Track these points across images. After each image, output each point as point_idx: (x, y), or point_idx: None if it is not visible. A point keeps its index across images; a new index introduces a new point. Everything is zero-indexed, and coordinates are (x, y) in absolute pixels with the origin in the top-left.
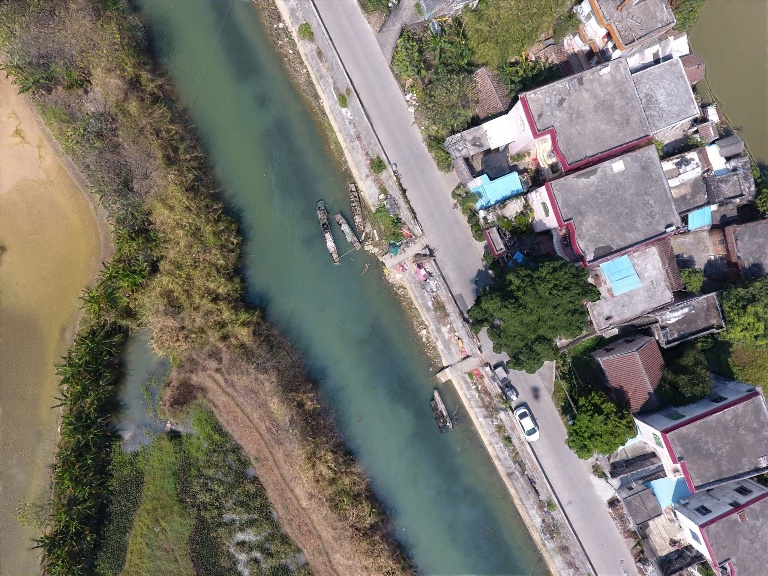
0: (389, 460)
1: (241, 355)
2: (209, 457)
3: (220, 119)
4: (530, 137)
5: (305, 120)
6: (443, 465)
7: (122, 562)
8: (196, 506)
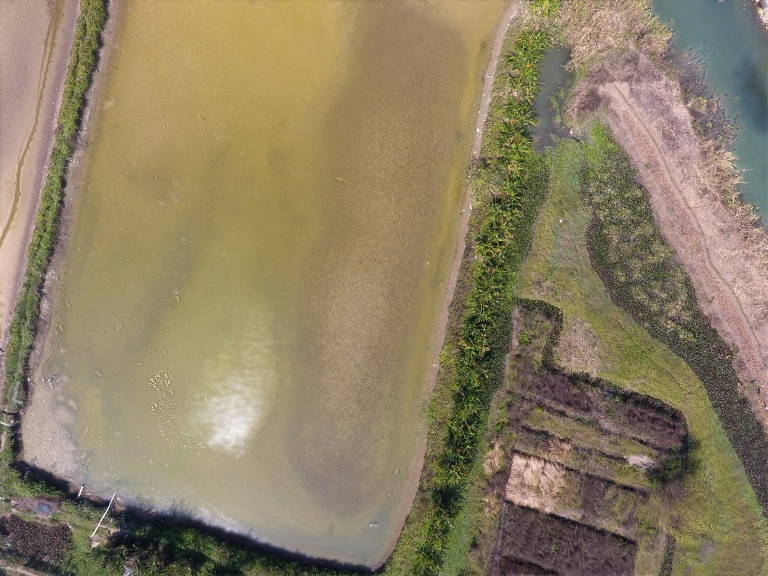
0: (754, 179)
1: (654, 63)
2: (604, 163)
3: None
4: None
5: None
6: None
7: (529, 248)
8: (592, 205)
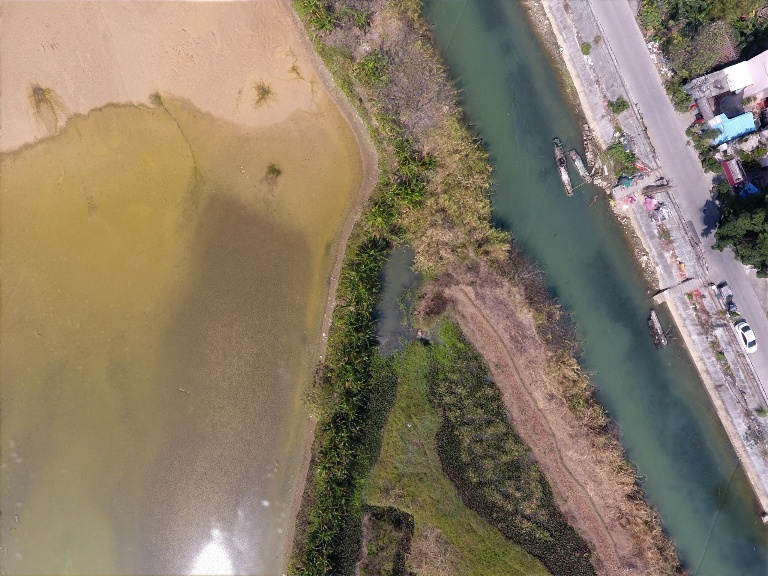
0: (610, 372)
1: (496, 269)
2: (454, 363)
3: (471, 62)
4: None
5: (544, 66)
6: (656, 378)
7: (378, 454)
8: (442, 406)
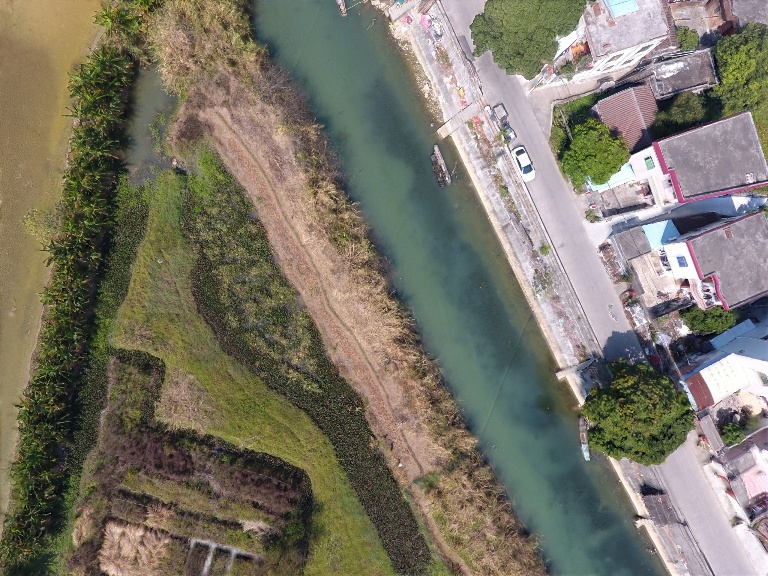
0: (388, 211)
1: (248, 86)
2: (213, 197)
3: None
4: None
5: None
6: (440, 220)
7: (125, 292)
8: (199, 243)
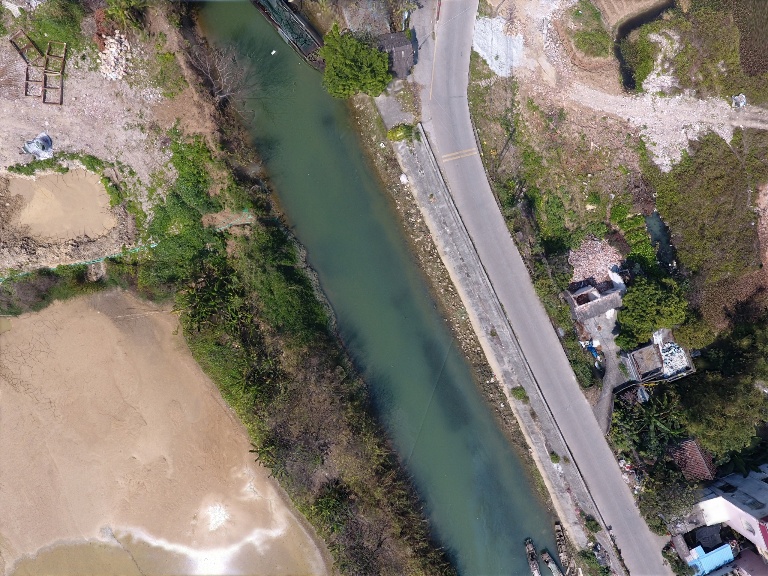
0: None
1: None
2: None
3: (437, 468)
4: (761, 547)
5: (513, 464)
6: None
7: None
8: None
